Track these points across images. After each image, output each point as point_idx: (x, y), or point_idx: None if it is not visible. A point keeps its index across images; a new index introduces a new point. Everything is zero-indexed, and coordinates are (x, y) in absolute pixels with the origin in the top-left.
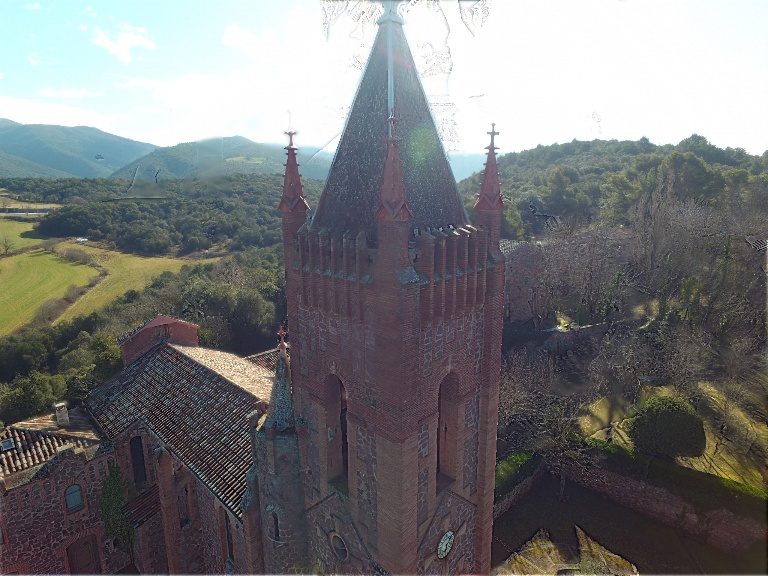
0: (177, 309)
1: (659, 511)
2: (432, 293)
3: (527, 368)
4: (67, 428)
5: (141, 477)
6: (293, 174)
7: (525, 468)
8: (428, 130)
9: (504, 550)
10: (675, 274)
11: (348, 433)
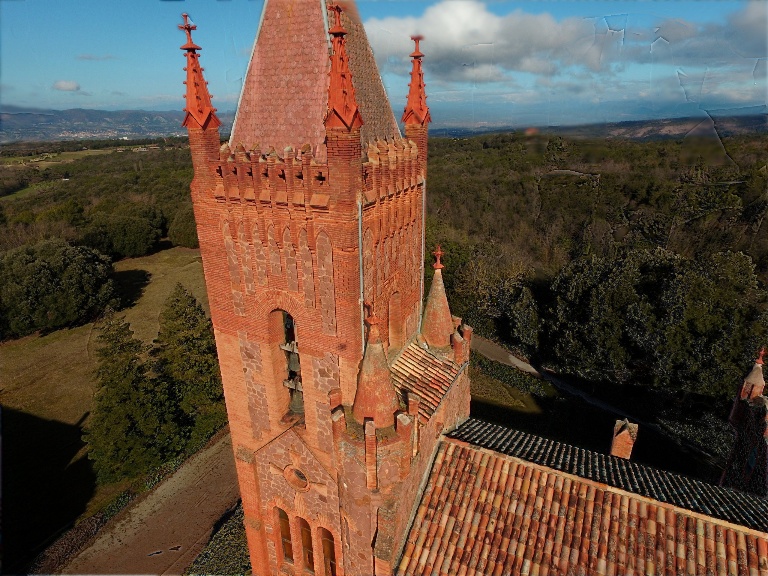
0: None
1: None
2: None
3: None
4: None
5: None
6: None
7: None
8: None
9: None
10: None
11: None
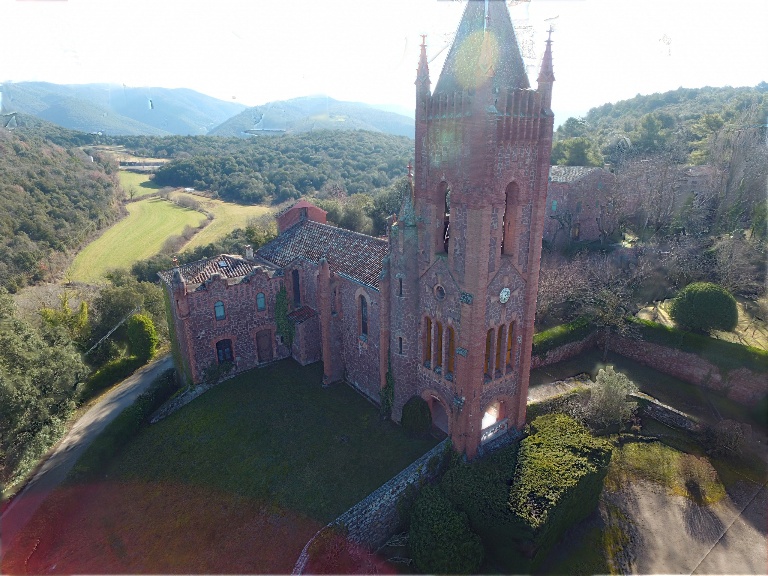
0: None
1: (689, 373)
2: (504, 123)
3: (586, 262)
4: (253, 262)
5: (297, 299)
6: (424, 61)
7: (576, 334)
8: (508, 30)
9: (551, 379)
10: (746, 197)
11: (450, 215)
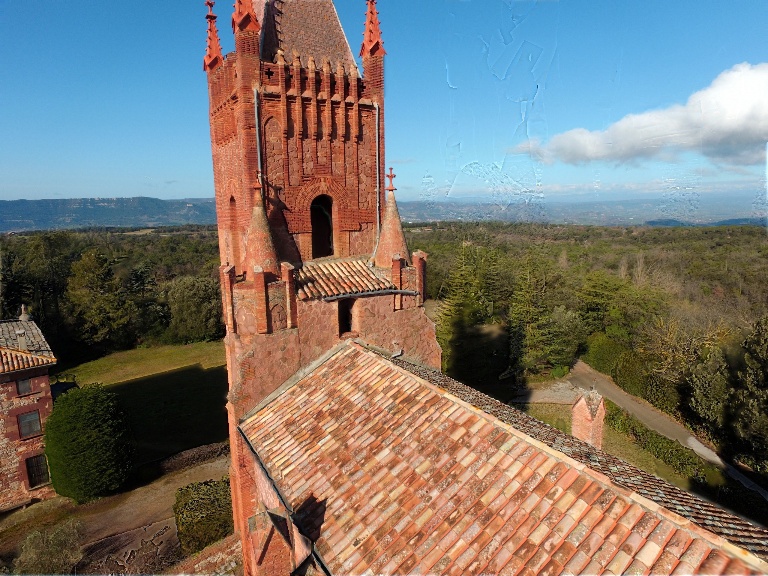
0: None
1: None
2: None
3: None
4: None
5: None
6: None
7: None
8: None
9: None
10: None
11: None
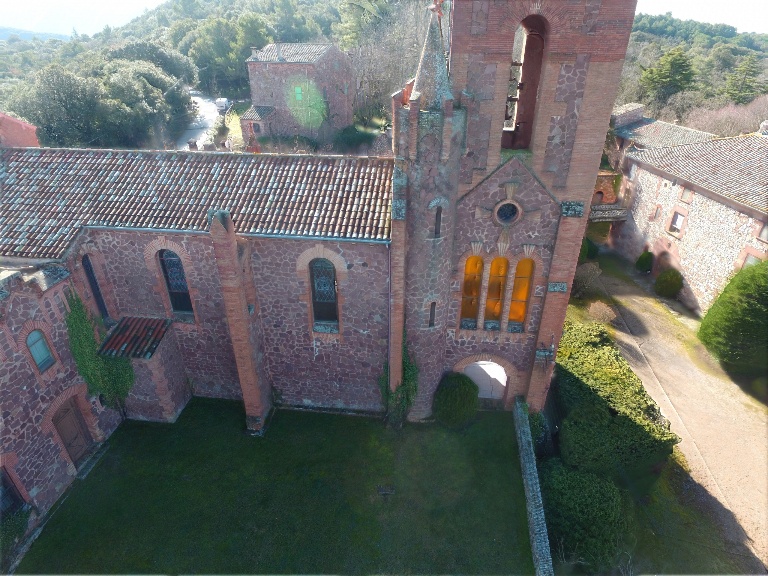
0: None
1: None
2: None
3: None
4: None
5: None
6: None
7: None
8: None
9: None
10: None
11: (546, 78)
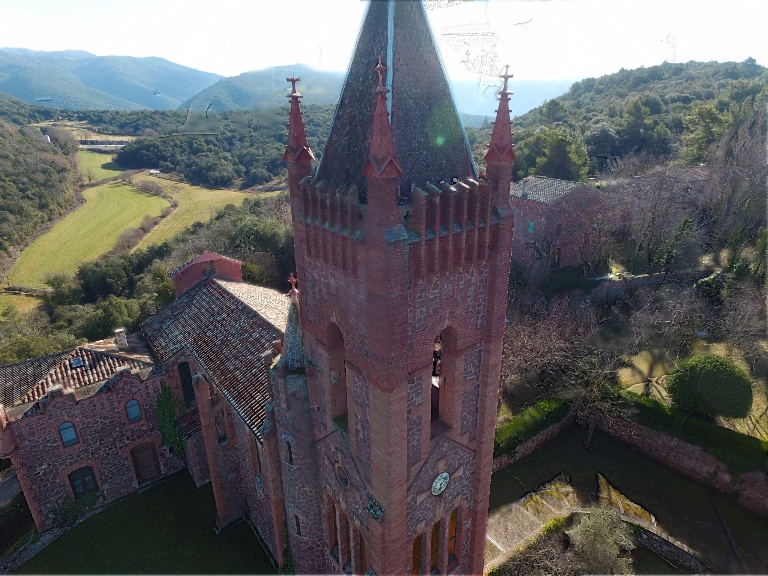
0: (231, 244)
1: (690, 467)
2: (423, 251)
3: (566, 317)
4: (126, 351)
5: (190, 397)
6: (296, 123)
7: (553, 415)
8: (434, 74)
9: (521, 489)
10: (752, 222)
11: (347, 378)
